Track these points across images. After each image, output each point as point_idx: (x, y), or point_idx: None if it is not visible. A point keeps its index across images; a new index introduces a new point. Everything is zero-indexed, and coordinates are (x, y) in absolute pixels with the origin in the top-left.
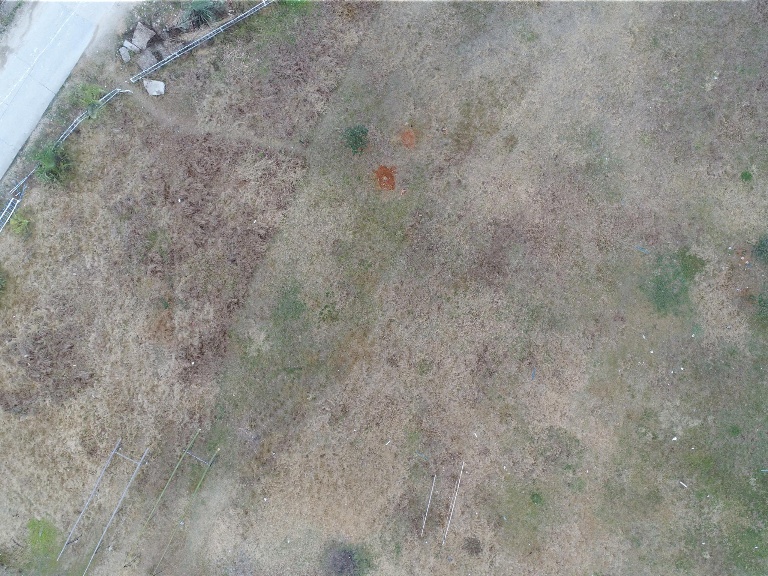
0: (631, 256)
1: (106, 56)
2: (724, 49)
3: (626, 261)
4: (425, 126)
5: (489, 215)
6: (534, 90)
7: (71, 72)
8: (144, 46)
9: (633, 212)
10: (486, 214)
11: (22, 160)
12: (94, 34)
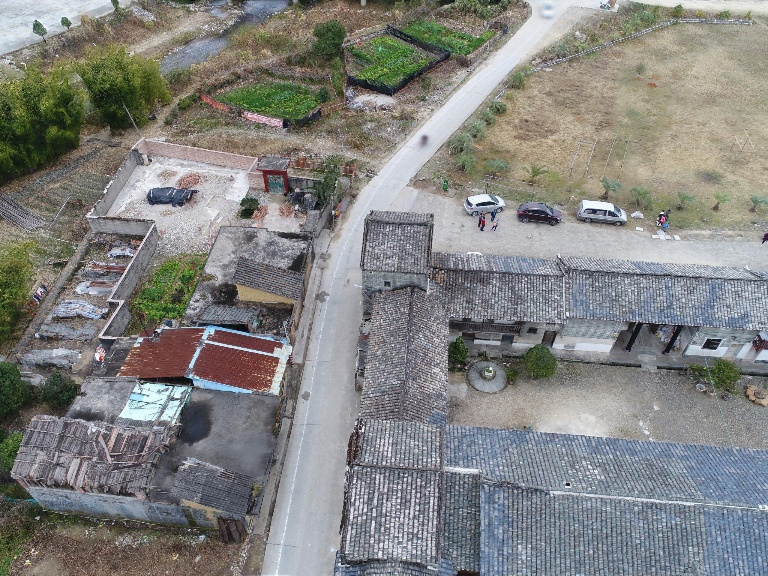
0: (767, 98)
1: (526, 64)
2: (759, 59)
3: (766, 99)
4: (659, 75)
5: (701, 91)
6: (695, 68)
7: (514, 67)
8: (541, 62)
9: (758, 89)
10: (699, 91)
11: (502, 85)
12: (520, 60)
